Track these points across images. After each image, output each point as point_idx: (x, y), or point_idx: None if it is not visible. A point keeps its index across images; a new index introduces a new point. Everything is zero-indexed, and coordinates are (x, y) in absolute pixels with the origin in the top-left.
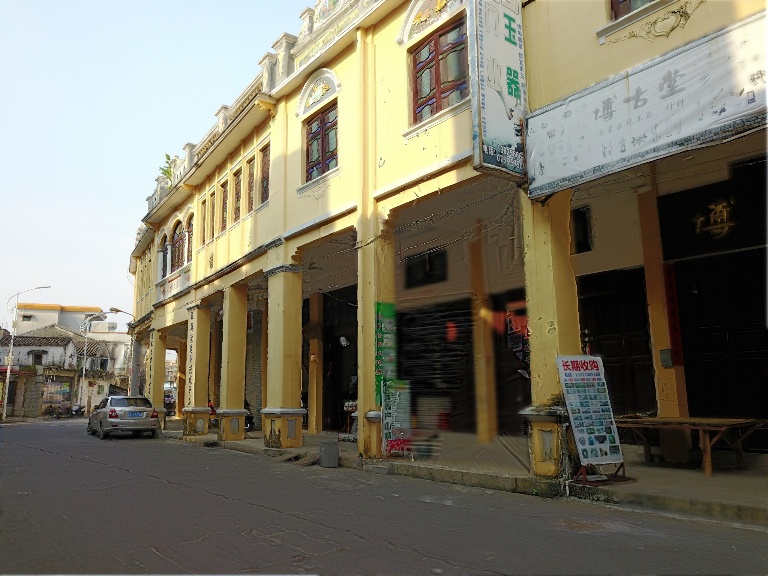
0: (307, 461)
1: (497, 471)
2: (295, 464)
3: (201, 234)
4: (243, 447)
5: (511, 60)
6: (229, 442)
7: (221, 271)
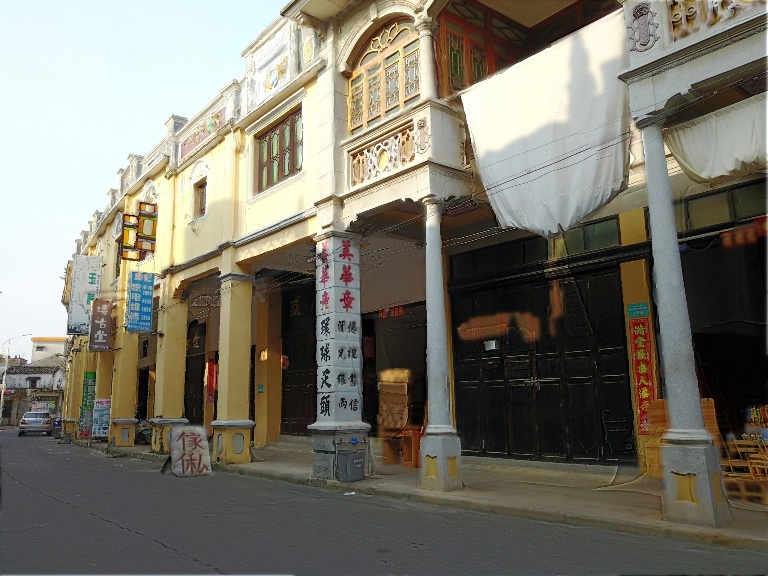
0: (61, 441)
1: None
2: None
3: None
4: None
5: (90, 291)
6: None
7: (70, 345)
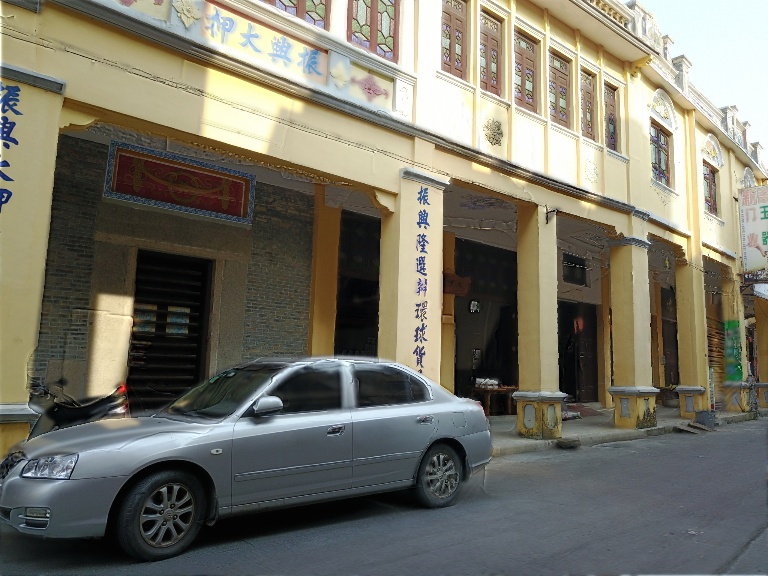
0: None
1: (736, 413)
2: (714, 431)
3: (440, 43)
4: (616, 436)
5: None
6: (580, 436)
7: (551, 180)
